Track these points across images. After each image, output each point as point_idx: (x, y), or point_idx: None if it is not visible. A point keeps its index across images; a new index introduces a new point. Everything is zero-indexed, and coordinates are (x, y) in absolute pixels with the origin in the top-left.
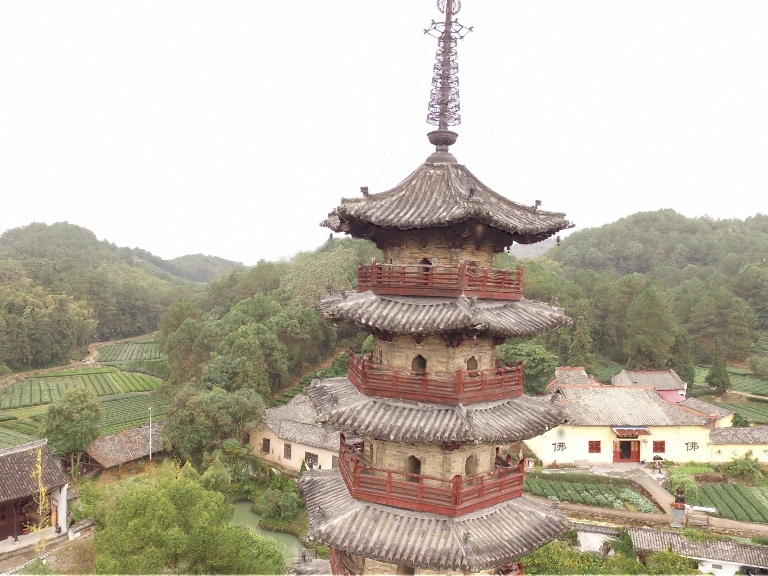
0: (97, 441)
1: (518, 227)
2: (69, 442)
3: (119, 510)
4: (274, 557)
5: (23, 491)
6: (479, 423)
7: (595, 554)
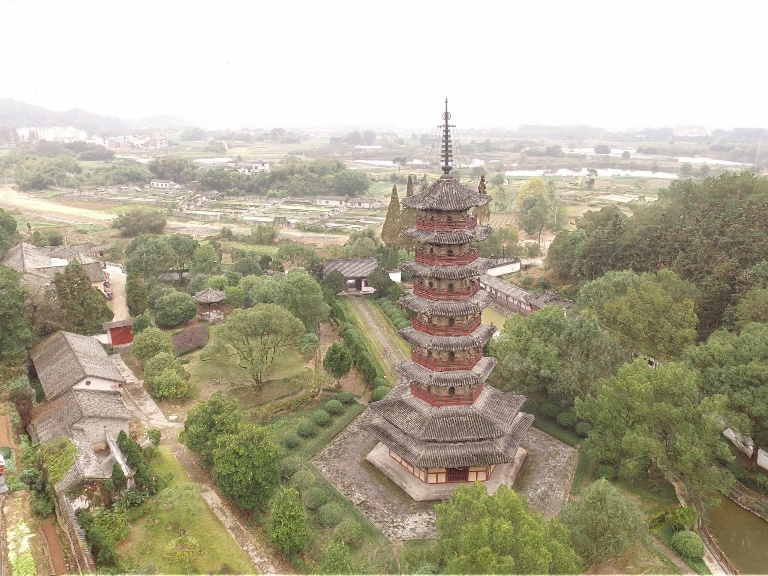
0: None
1: None
2: None
3: None
4: None
5: None
6: None
7: (95, 517)
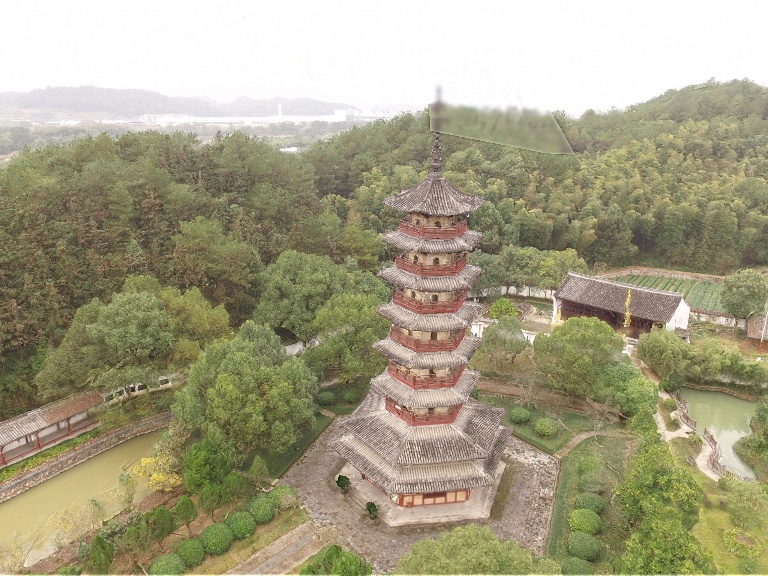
0: (767, 318)
1: (401, 209)
2: (728, 307)
3: (647, 343)
4: (629, 395)
5: (643, 315)
6: (395, 274)
7: None
